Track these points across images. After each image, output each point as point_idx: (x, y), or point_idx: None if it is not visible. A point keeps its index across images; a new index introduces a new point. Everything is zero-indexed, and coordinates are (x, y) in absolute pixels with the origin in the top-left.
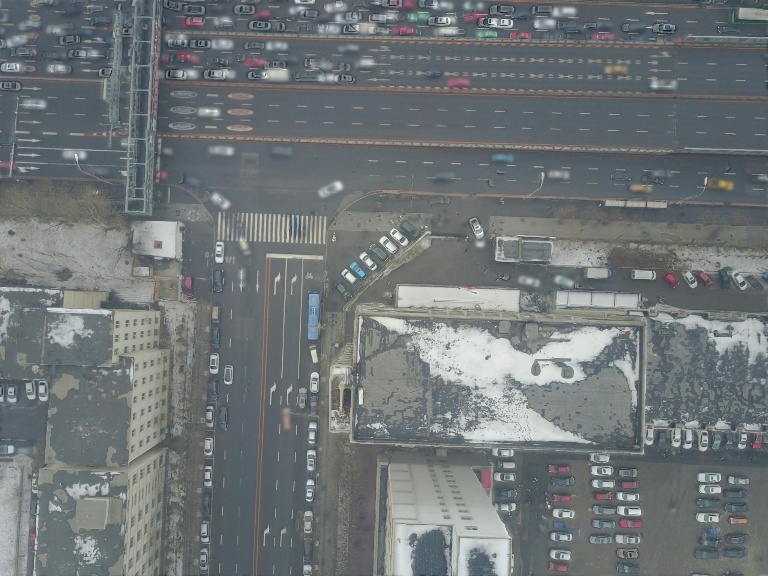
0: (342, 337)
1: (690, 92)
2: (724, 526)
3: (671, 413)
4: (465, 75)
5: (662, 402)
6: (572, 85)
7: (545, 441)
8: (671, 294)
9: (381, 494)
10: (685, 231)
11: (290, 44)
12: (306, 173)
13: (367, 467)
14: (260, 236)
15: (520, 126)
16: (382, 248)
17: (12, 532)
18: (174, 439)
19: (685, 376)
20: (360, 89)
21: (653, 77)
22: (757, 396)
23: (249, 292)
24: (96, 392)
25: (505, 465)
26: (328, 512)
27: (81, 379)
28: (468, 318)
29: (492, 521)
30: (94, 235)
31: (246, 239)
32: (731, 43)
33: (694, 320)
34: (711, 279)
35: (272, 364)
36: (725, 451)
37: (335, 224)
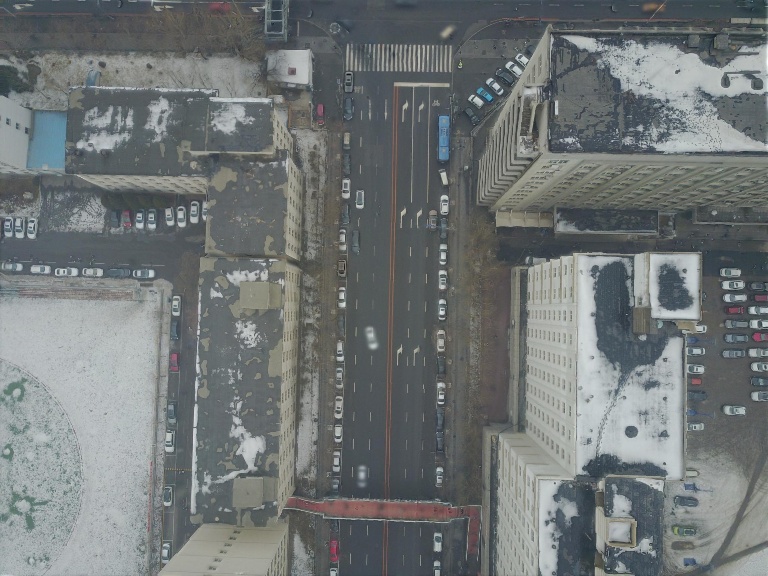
0: (470, 161)
1: None
2: None
3: None
4: None
5: None
6: None
7: (736, 151)
8: None
9: (521, 298)
10: None
11: None
12: (431, 4)
13: (498, 286)
14: (387, 66)
15: None
16: (508, 73)
17: (153, 353)
18: (308, 262)
19: None
20: None
21: None
22: None
23: (378, 120)
24: (253, 183)
25: None
26: (460, 331)
27: (239, 171)
28: (658, 32)
29: None
30: (233, 59)
31: (374, 69)
32: None
33: None
34: None
35: (402, 189)
36: None
37: (460, 52)
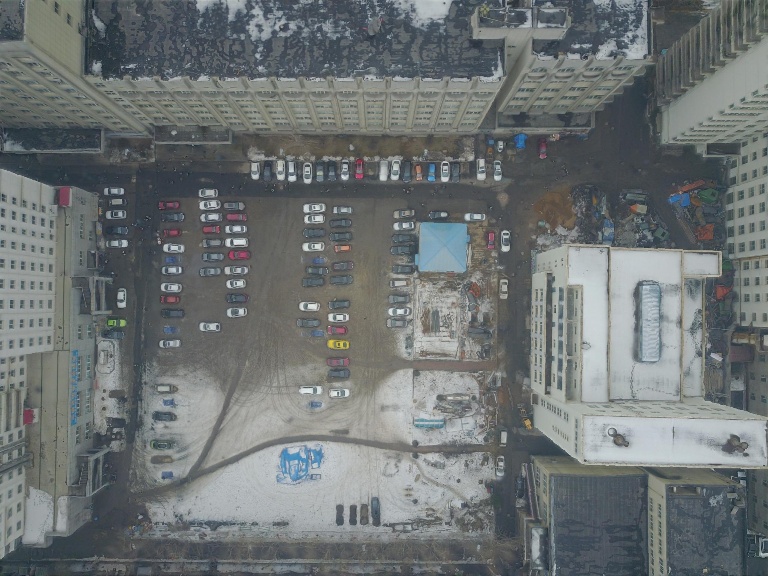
0: None
1: None
2: (331, 256)
3: (155, 70)
4: None
5: (147, 60)
6: None
7: None
8: None
9: None
10: None
11: None
12: None
13: None
14: None
15: None
16: None
17: None
18: None
19: (168, 34)
20: None
21: None
22: (238, 51)
23: None
24: None
25: (113, 202)
26: None
27: None
28: None
29: None
30: None
31: None
32: None
33: None
34: None
35: None
36: (330, 183)
37: None
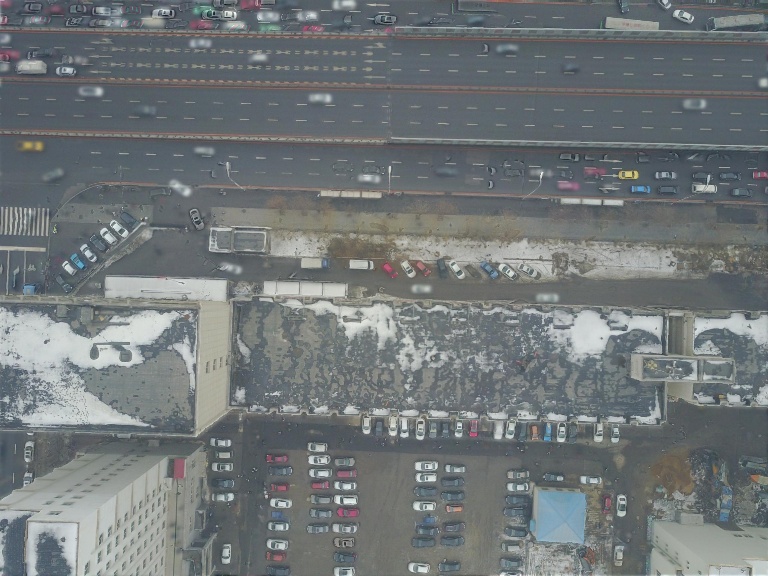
0: None
1: (404, 82)
2: (442, 514)
3: (301, 398)
4: (184, 67)
5: (292, 388)
6: (289, 76)
7: (103, 424)
8: (390, 284)
9: None
10: (405, 221)
11: (14, 37)
12: (29, 165)
13: None
14: None
15: (238, 117)
16: (102, 240)
17: None
18: None
19: (315, 362)
20: (81, 81)
21: (368, 68)
22: (386, 381)
23: None
24: None
25: (220, 455)
26: None
27: None
28: (24, 302)
29: (89, 506)
30: None
31: None
32: (442, 34)
33: (324, 306)
34: (429, 268)
35: None
36: (443, 440)
37: (58, 216)
